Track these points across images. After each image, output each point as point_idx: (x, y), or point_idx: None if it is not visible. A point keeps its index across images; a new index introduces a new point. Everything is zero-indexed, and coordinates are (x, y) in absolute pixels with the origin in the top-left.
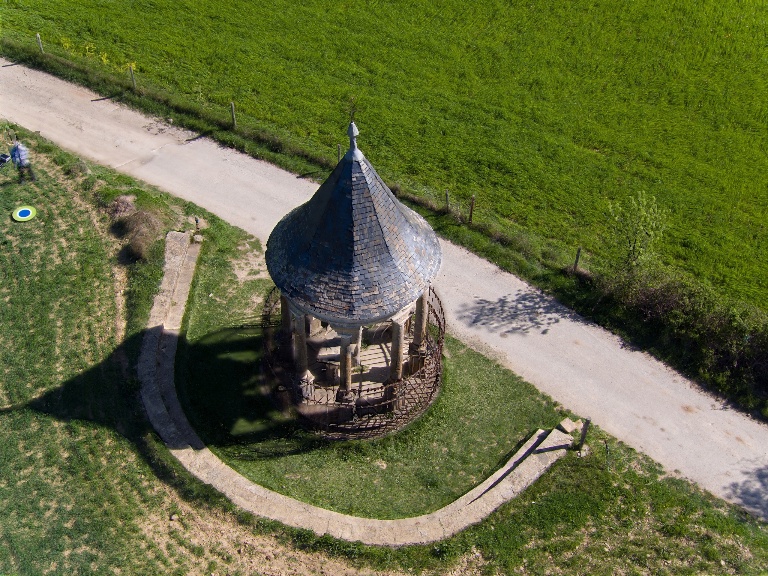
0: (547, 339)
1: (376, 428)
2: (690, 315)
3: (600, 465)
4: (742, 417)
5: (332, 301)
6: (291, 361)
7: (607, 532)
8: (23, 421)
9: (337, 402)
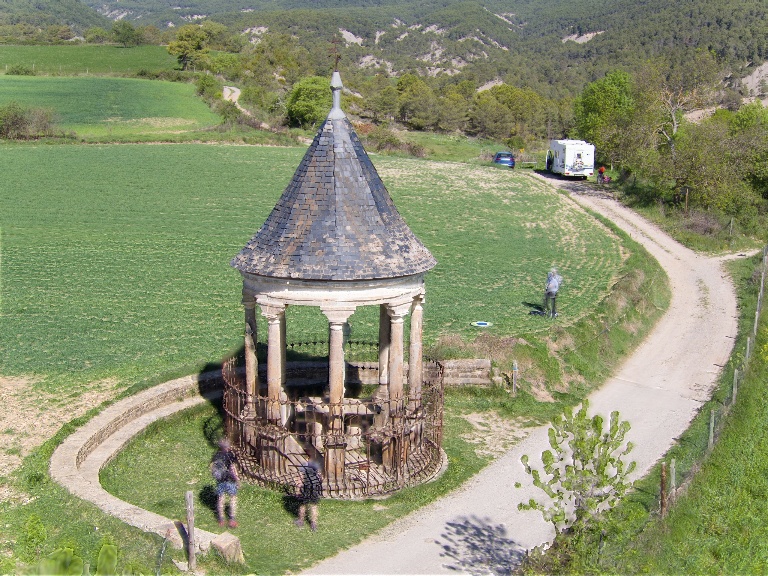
0: (432, 567)
1: None
2: None
3: None
4: None
5: None
6: None
7: None
8: None
9: None
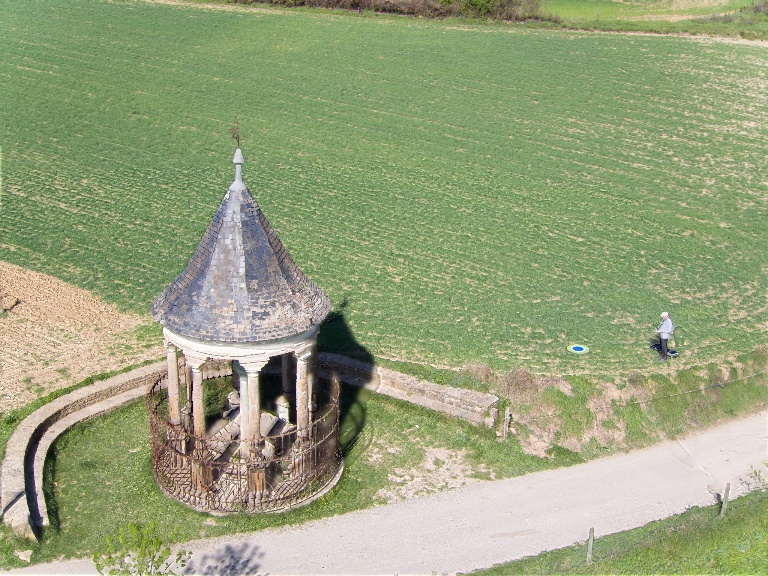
0: None
1: None
2: None
3: None
4: None
5: None
6: None
7: None
8: None
9: None
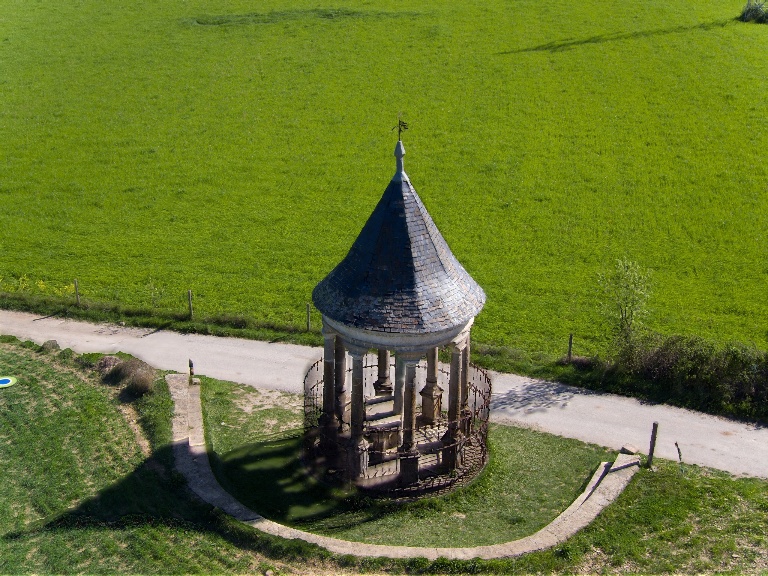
0: (570, 409)
1: (441, 488)
2: (696, 360)
3: None
4: None
5: (400, 319)
6: (334, 448)
7: (712, 517)
8: (65, 525)
9: (402, 457)
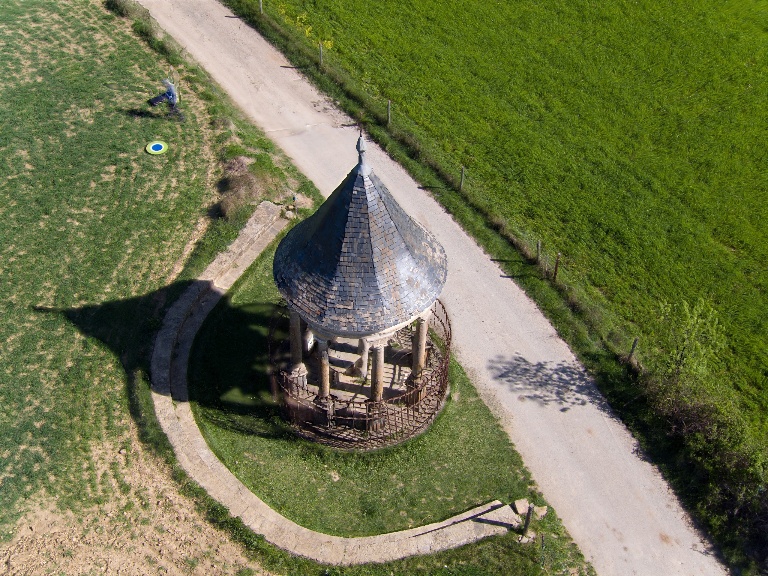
0: (562, 417)
1: (348, 441)
2: (711, 444)
3: (536, 557)
4: (719, 569)
5: (308, 302)
6: (303, 352)
7: None
8: (53, 323)
9: None
